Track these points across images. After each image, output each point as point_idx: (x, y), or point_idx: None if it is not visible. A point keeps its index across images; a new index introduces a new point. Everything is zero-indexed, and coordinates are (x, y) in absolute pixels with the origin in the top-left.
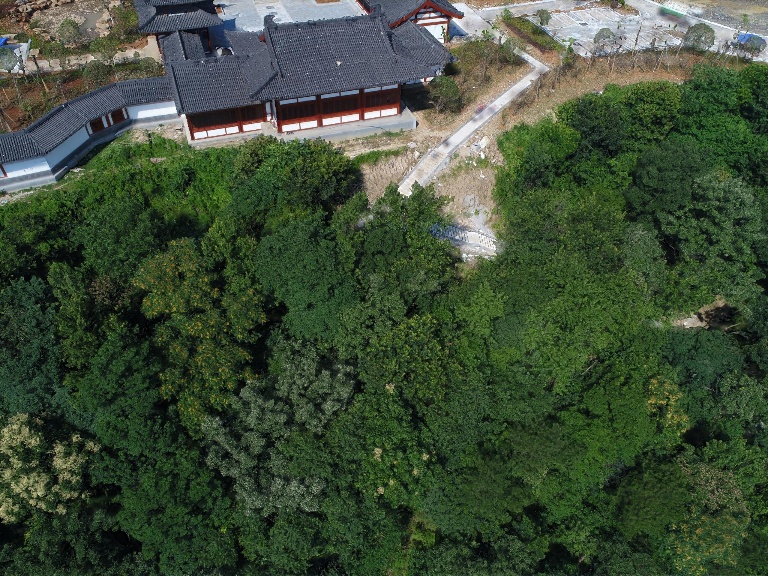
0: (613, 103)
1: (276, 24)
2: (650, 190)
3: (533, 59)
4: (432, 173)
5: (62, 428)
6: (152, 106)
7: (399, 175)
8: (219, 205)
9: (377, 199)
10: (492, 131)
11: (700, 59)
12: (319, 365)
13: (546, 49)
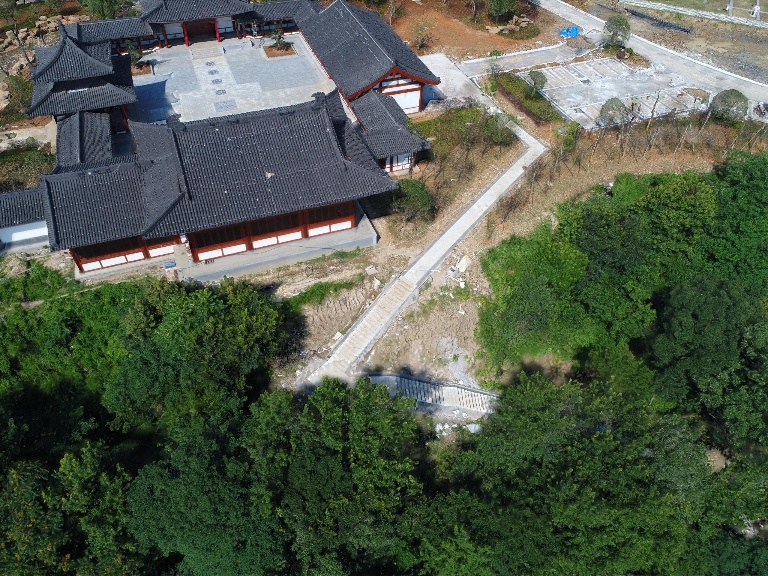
0: (628, 205)
1: (184, 125)
2: (682, 341)
3: (526, 134)
4: (396, 312)
5: None
6: (30, 226)
7: (354, 312)
8: (113, 364)
9: None
10: (474, 248)
11: (730, 132)
12: None
13: (541, 120)
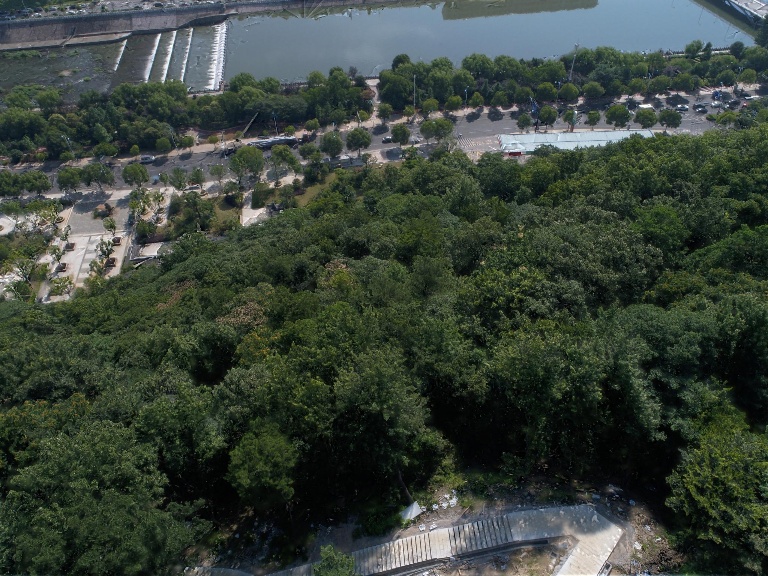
0: None
1: None
2: None
3: None
4: None
5: None
6: None
7: None
8: None
9: (605, 374)
10: None
11: None
12: (592, 304)
13: None
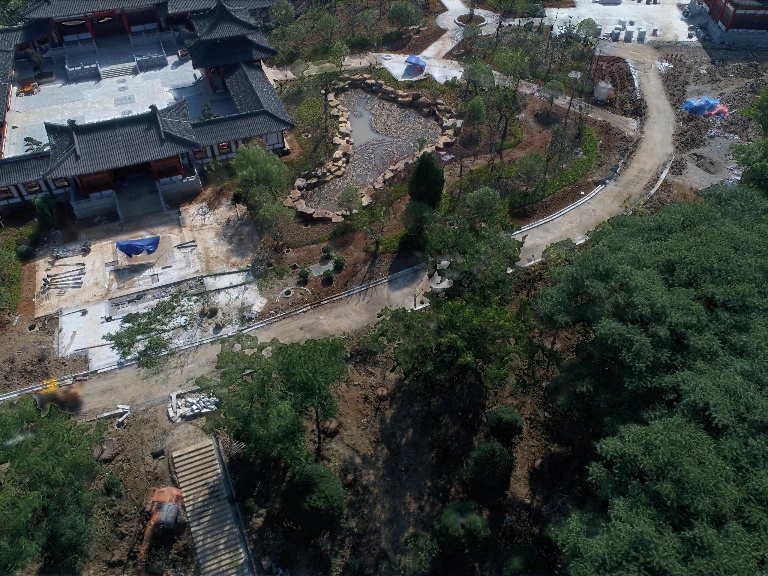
0: None
1: None
2: None
3: None
4: None
5: None
6: None
7: None
8: None
9: None
10: (0, 27)
11: None
12: None
13: None
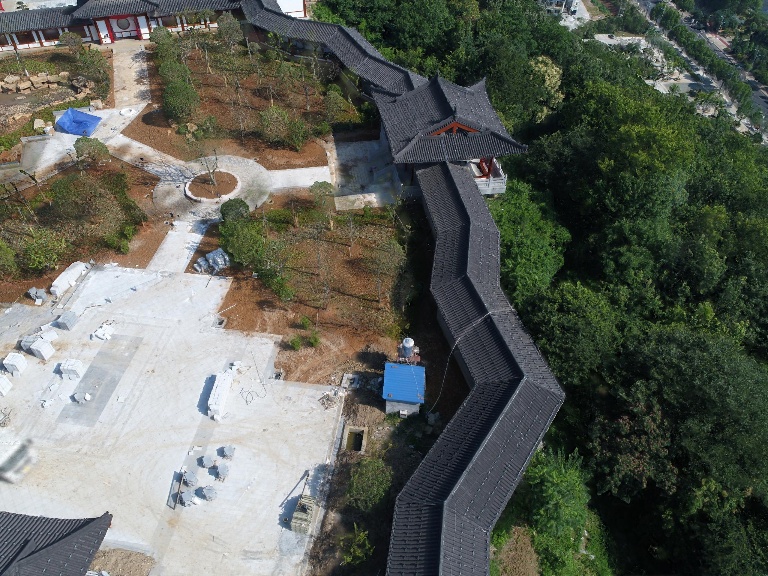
0: None
1: None
2: None
3: None
4: None
5: (523, 73)
6: None
7: None
8: None
9: None
10: None
11: None
12: None
13: None
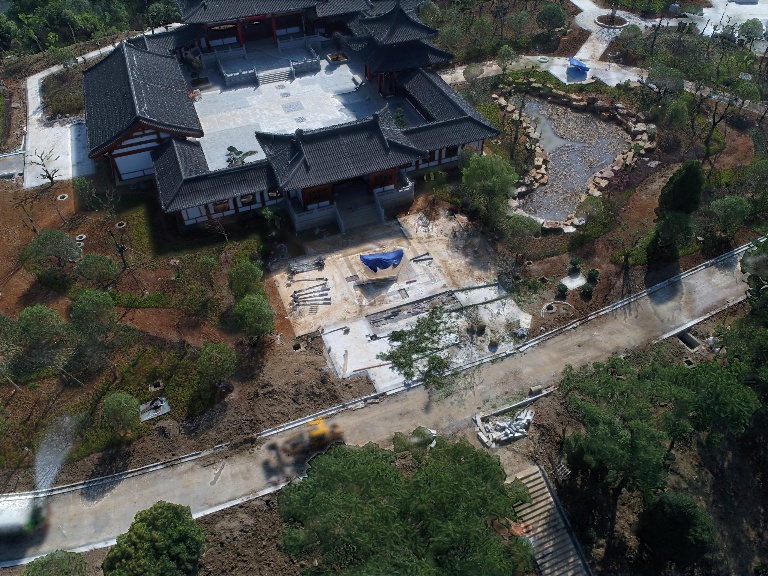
0: None
1: None
2: None
3: (30, 91)
4: None
5: None
6: None
7: None
8: None
9: None
10: (132, 32)
11: None
12: None
13: (6, 94)
